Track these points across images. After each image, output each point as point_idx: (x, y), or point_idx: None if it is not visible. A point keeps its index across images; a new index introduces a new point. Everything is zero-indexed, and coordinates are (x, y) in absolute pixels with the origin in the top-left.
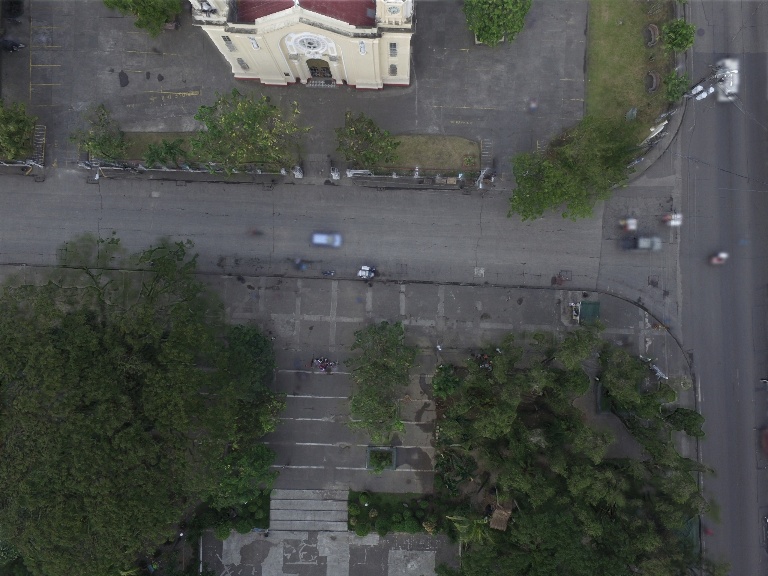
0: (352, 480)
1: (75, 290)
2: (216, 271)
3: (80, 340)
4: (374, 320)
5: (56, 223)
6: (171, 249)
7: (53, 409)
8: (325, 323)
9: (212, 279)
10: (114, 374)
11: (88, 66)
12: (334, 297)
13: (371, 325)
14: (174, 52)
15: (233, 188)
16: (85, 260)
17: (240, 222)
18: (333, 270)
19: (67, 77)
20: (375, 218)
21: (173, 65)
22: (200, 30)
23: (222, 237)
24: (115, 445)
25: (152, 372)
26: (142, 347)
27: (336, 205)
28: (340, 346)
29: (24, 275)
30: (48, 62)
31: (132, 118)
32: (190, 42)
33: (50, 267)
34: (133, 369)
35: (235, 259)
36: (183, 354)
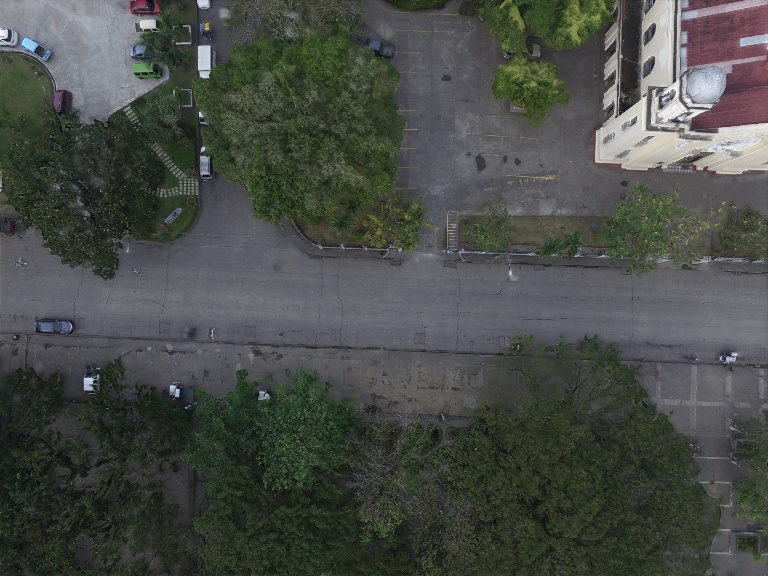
0: (715, 565)
1: (564, 403)
2: (575, 355)
3: (598, 460)
4: (734, 404)
5: (414, 307)
6: (530, 333)
7: (585, 533)
8: (685, 407)
9: (572, 363)
10: (629, 493)
11: (445, 150)
12: (694, 381)
13: (759, 415)
14: (531, 136)
15: (591, 272)
16: (444, 344)
17: (599, 306)
18: (693, 354)
19: (424, 160)
20: (733, 302)
21: (530, 149)
22: (557, 114)
23: (581, 321)
24: (644, 568)
25: (659, 489)
26: (640, 462)
27: (694, 289)
28: (701, 430)
29: (382, 360)
30: (404, 145)
31: (489, 202)
32: (547, 126)
33: (408, 351)
34: (643, 487)
35: (594, 343)
36: (682, 469)
